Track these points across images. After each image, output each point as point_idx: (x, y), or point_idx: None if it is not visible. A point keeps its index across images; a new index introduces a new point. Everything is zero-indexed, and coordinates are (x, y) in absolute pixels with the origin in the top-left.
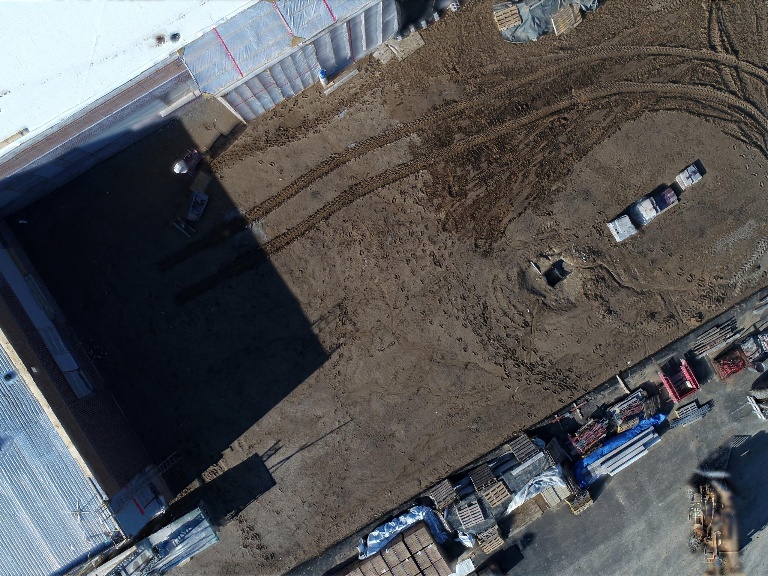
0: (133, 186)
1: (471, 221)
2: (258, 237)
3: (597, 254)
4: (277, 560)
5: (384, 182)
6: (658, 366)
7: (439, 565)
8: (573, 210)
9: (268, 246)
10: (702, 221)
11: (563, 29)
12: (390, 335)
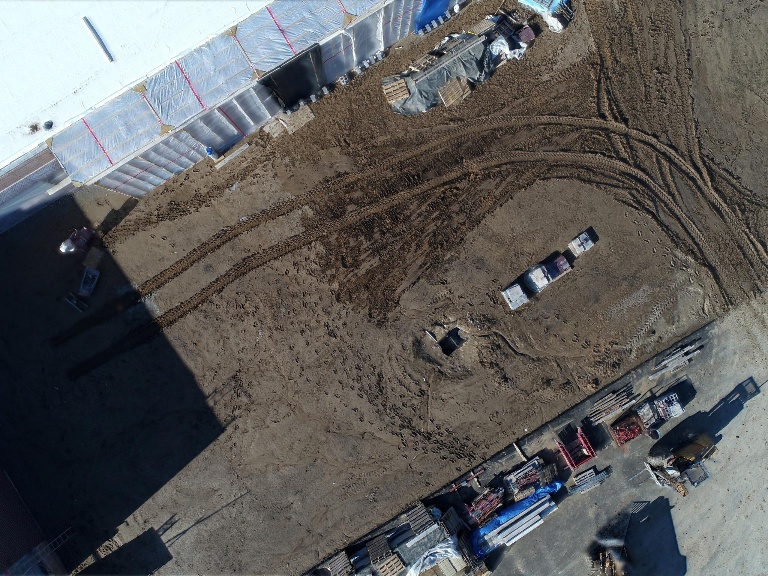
0: (25, 262)
1: (365, 291)
2: (151, 311)
3: (492, 322)
4: None
5: (277, 254)
6: (555, 433)
7: None
8: (467, 279)
9: (161, 319)
10: (596, 288)
11: (452, 101)
12: (286, 406)
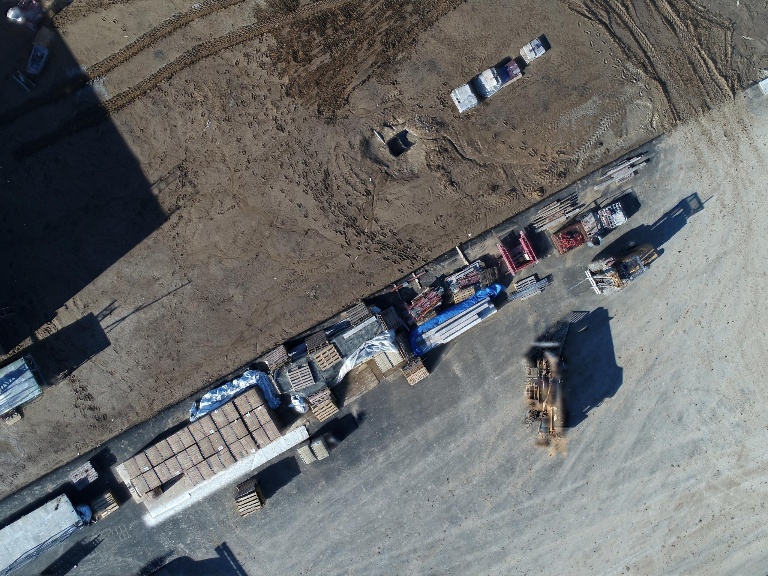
0: None
1: (315, 87)
2: (99, 94)
3: (440, 125)
4: (109, 421)
5: (228, 44)
6: (498, 239)
7: (268, 427)
8: (417, 80)
9: (109, 104)
10: (546, 96)
11: None
12: (230, 198)
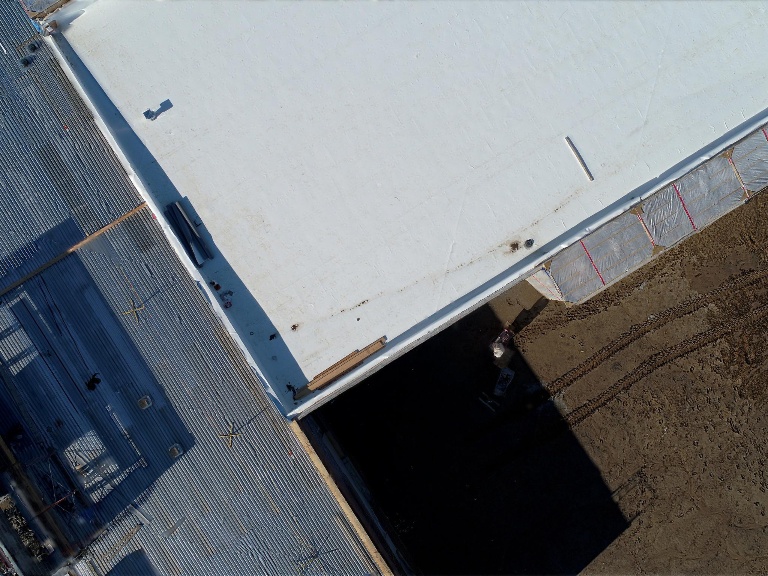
0: (438, 362)
1: (767, 387)
2: (560, 408)
3: None
4: None
5: (682, 351)
6: None
7: None
8: None
9: (569, 417)
10: None
11: None
12: (689, 501)
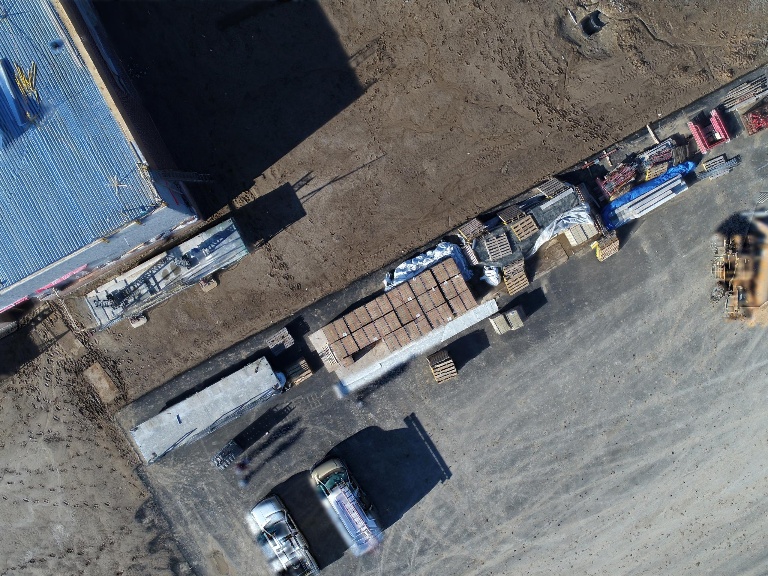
0: None
1: None
2: None
3: (633, 5)
4: (303, 290)
5: None
6: (688, 119)
7: (465, 296)
8: None
9: None
10: None
11: None
12: (426, 73)
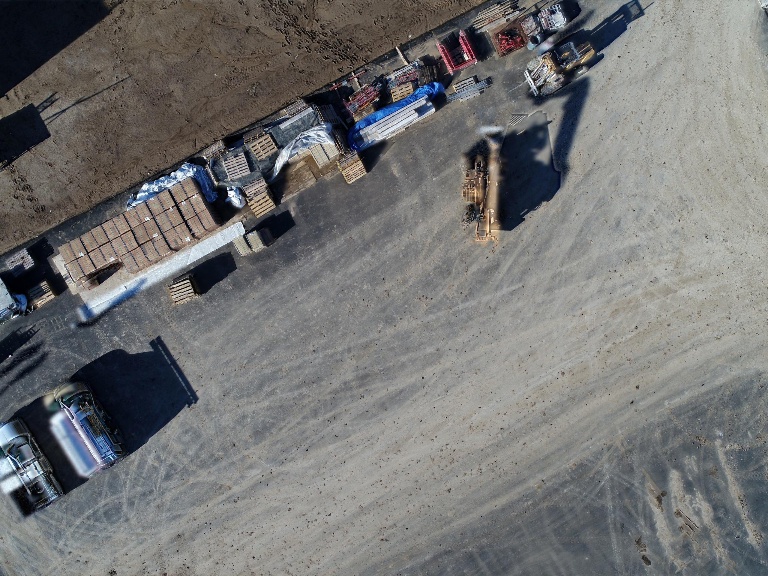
0: None
1: None
2: None
3: None
4: (47, 212)
5: None
6: (438, 40)
7: (203, 216)
8: None
9: None
10: None
11: None
12: None
